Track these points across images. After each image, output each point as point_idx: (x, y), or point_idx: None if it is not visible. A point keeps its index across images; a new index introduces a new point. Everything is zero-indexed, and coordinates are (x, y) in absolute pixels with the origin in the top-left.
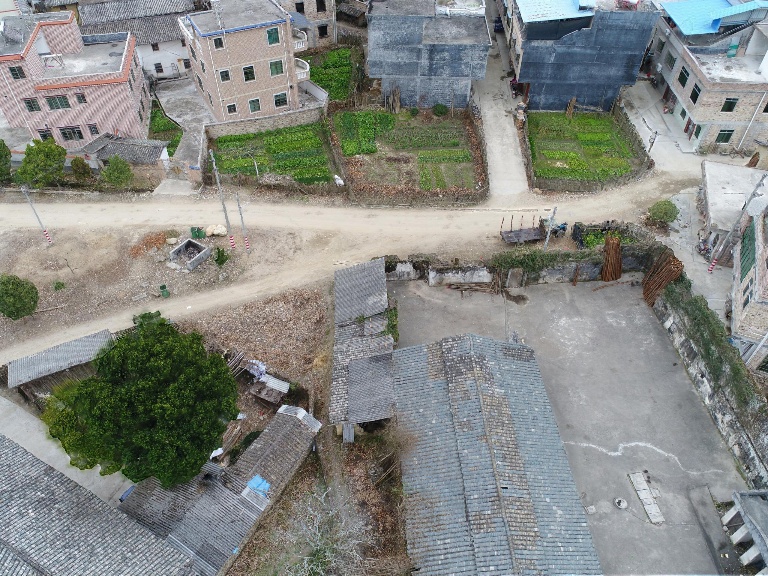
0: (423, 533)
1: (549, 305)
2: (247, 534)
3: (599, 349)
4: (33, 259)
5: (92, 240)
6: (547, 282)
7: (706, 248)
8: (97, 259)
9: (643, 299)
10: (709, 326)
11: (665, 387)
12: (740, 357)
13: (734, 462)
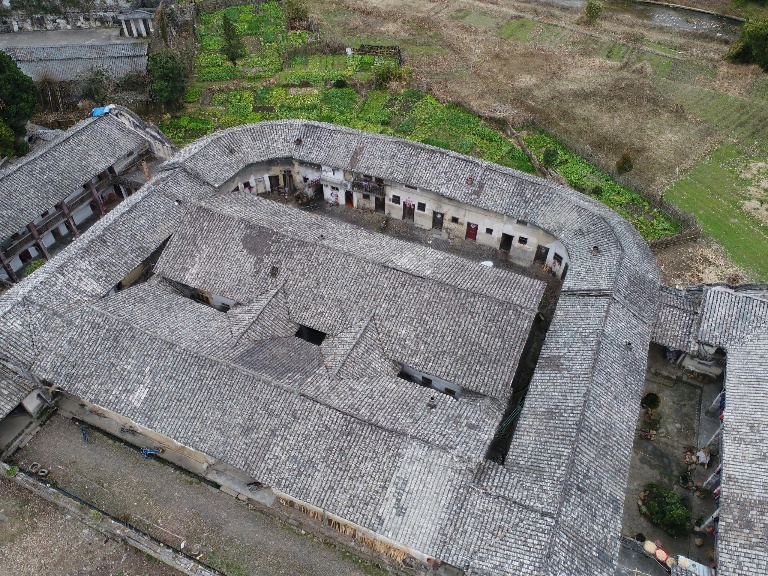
0: None
1: None
2: None
3: None
4: None
5: None
6: None
7: None
8: None
9: None
10: None
11: (54, 36)
12: None
13: (103, 28)
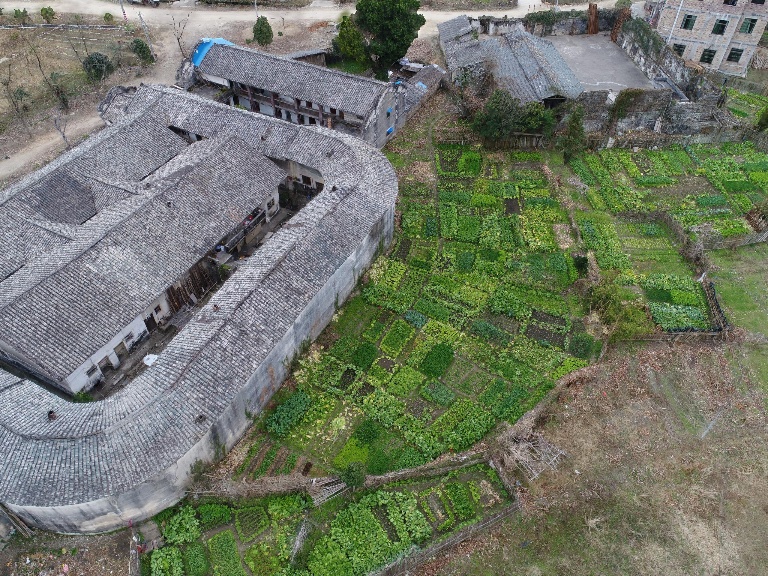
0: (506, 86)
1: (558, 43)
2: (418, 104)
3: (586, 56)
4: (251, 32)
5: (282, 25)
6: (556, 35)
7: (648, 20)
8: (290, 32)
9: (611, 40)
10: (643, 27)
11: (621, 66)
12: (657, 34)
13: None
